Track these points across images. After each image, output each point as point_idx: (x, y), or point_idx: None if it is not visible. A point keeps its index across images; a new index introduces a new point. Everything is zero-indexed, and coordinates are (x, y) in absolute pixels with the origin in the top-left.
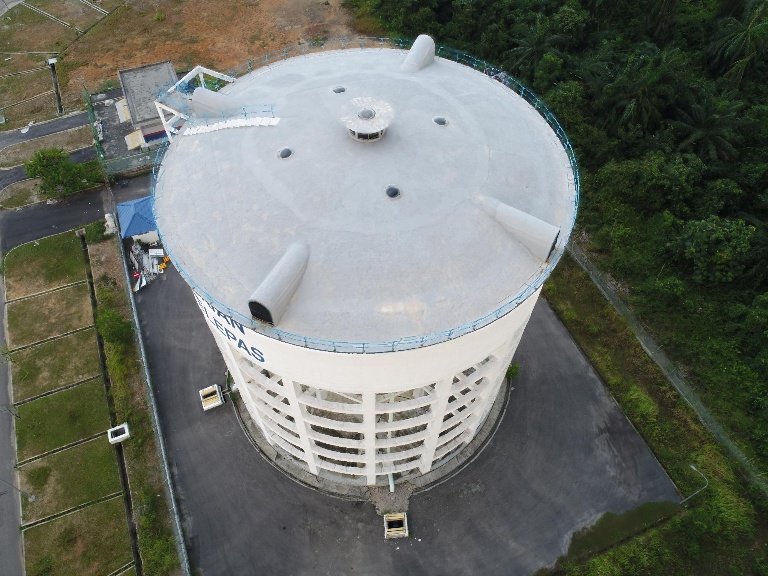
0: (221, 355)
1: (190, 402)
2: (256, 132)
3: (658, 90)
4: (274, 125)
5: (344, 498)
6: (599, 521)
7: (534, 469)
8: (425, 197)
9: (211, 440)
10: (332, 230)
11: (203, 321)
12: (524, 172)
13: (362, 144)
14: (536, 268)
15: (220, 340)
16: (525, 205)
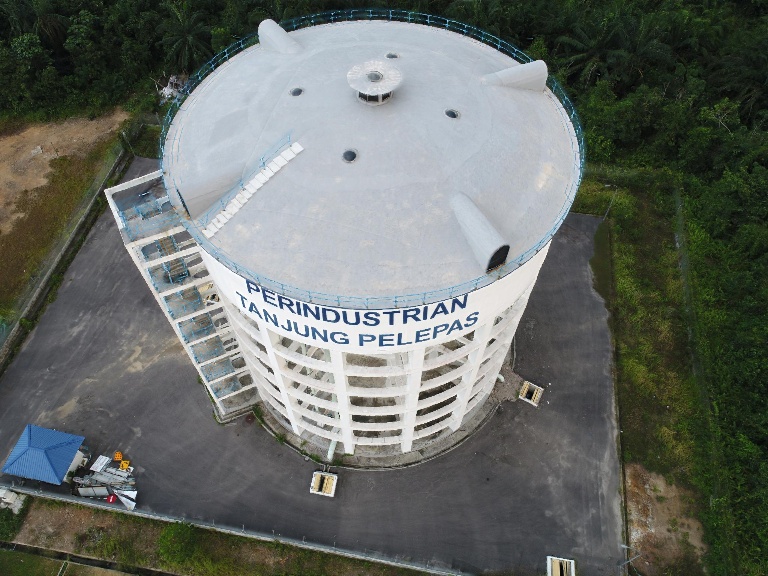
0: (283, 454)
1: (314, 507)
2: (295, 167)
3: (316, 3)
4: (302, 150)
5: (488, 419)
6: (593, 269)
7: (537, 281)
8: (467, 102)
9: (368, 505)
10: (458, 169)
11: (230, 454)
12: (465, 52)
13: (389, 103)
14: (546, 97)
15: (391, 370)
16: (495, 68)
